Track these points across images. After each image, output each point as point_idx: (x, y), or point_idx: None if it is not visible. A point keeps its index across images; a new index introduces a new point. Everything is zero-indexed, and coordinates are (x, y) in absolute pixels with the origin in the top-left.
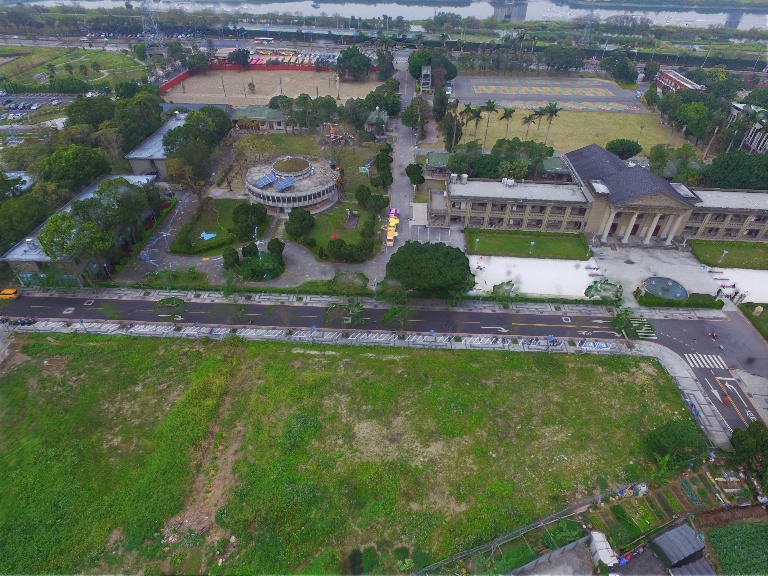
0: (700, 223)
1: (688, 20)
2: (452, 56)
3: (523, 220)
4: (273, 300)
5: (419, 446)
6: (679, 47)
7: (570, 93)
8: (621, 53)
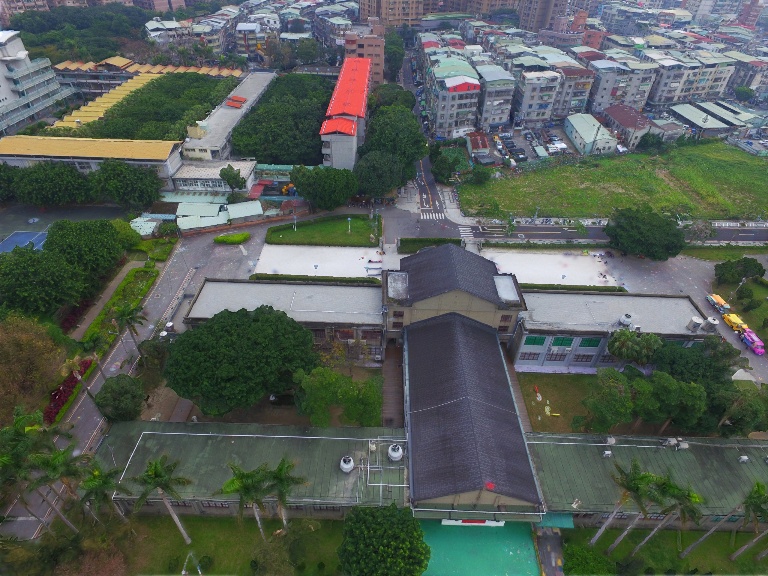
0: None
1: None
2: None
3: None
4: (746, 243)
5: (590, 186)
6: None
7: None
8: None
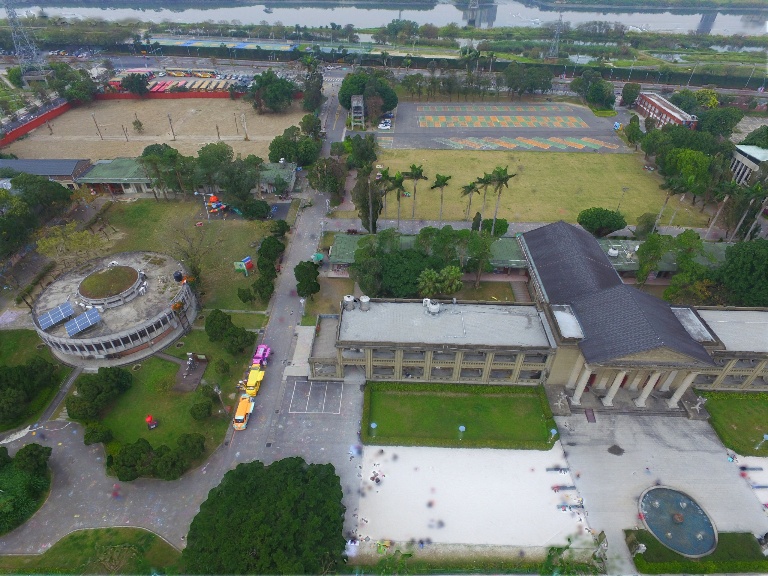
0: (719, 370)
1: (668, 29)
2: (394, 79)
3: (453, 369)
4: None
5: None
6: (658, 57)
7: (535, 124)
8: (594, 73)
